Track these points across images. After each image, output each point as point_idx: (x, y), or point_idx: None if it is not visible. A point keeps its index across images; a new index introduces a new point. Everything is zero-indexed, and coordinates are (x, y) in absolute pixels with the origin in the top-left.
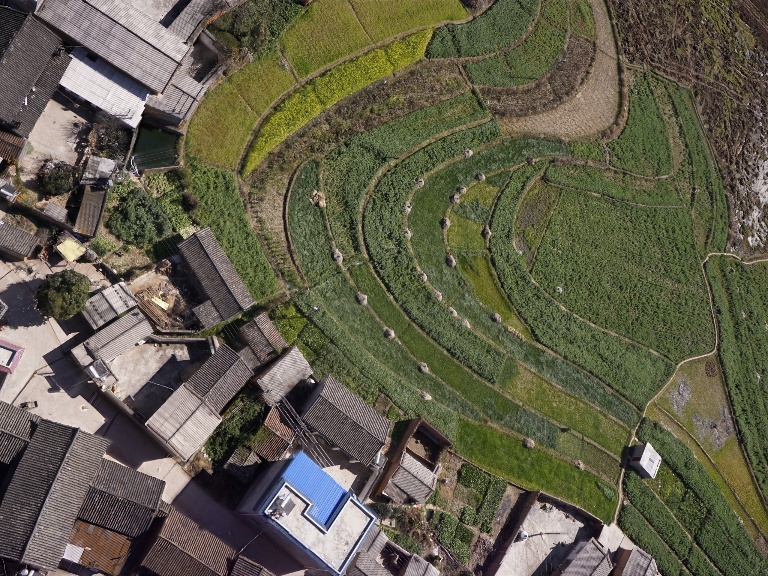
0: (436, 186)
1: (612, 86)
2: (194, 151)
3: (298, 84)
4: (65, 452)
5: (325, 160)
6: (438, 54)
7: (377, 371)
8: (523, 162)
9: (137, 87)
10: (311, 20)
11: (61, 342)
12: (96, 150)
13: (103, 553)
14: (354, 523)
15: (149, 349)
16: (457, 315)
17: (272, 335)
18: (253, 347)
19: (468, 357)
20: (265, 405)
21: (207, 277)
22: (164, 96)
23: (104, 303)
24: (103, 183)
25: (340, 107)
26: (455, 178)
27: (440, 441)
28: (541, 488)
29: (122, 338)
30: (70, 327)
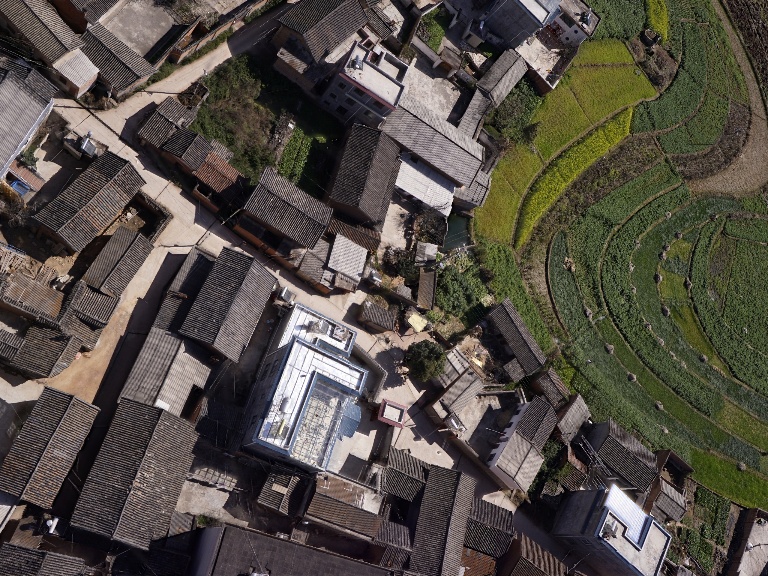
0: (647, 246)
1: (766, 145)
2: (480, 230)
3: (544, 166)
4: (455, 491)
5: (568, 230)
6: (639, 129)
7: (629, 410)
8: (708, 219)
9: (447, 182)
10: (547, 109)
11: (416, 399)
12: (419, 236)
13: (478, 571)
14: (657, 542)
15: (473, 401)
16: (676, 358)
17: (560, 385)
18: (547, 396)
19: (689, 394)
20: (562, 444)
21: (513, 339)
22: (465, 188)
23: (449, 366)
24: (431, 264)
25: (575, 183)
26: (660, 238)
27: (682, 468)
28: (754, 505)
29: (465, 394)
30: (420, 386)
